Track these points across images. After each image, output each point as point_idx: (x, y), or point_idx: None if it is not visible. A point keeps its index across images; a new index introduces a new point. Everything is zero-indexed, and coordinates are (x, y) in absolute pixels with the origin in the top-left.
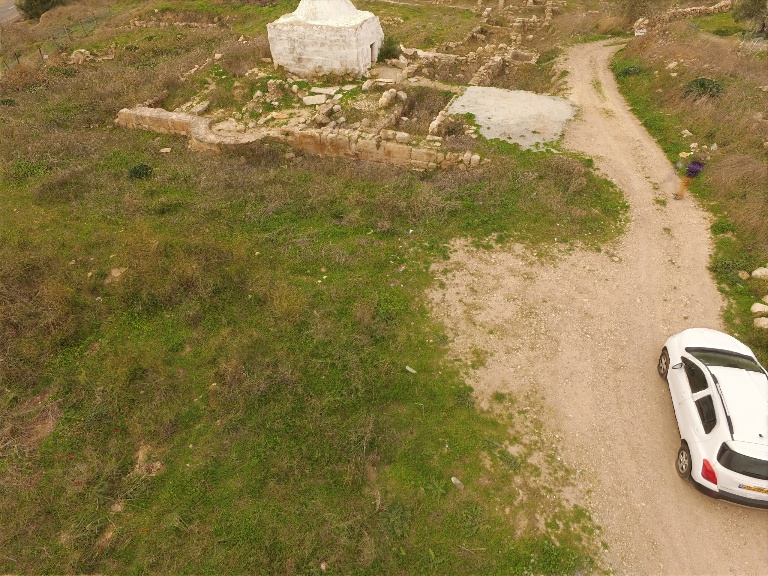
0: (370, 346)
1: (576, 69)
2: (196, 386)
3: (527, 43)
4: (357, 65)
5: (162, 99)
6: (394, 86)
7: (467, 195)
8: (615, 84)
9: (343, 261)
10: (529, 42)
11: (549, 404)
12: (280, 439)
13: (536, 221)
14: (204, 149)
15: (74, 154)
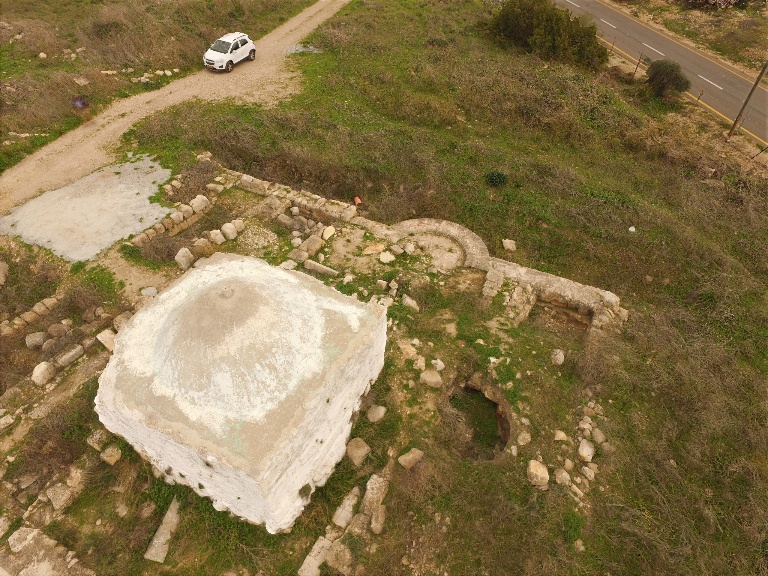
0: None
1: None
2: None
3: None
4: None
5: None
6: None
7: None
8: None
9: None
10: None
11: None
12: None
13: None
14: None
15: None
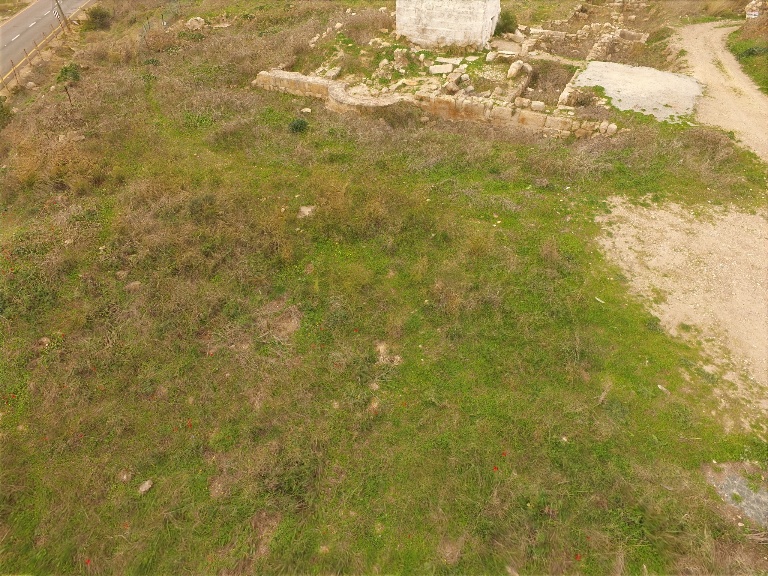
0: (559, 279)
1: (693, 49)
2: (409, 302)
3: (630, 23)
4: (480, 37)
5: (292, 64)
6: (520, 58)
7: (616, 159)
8: (737, 64)
9: (514, 209)
10: (631, 22)
11: (733, 336)
12: (498, 346)
13: (687, 185)
14: (342, 110)
15: (233, 109)
